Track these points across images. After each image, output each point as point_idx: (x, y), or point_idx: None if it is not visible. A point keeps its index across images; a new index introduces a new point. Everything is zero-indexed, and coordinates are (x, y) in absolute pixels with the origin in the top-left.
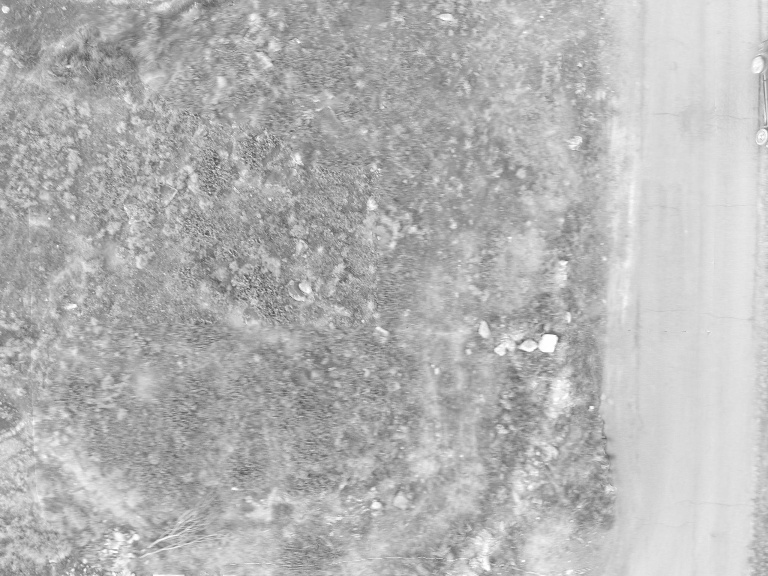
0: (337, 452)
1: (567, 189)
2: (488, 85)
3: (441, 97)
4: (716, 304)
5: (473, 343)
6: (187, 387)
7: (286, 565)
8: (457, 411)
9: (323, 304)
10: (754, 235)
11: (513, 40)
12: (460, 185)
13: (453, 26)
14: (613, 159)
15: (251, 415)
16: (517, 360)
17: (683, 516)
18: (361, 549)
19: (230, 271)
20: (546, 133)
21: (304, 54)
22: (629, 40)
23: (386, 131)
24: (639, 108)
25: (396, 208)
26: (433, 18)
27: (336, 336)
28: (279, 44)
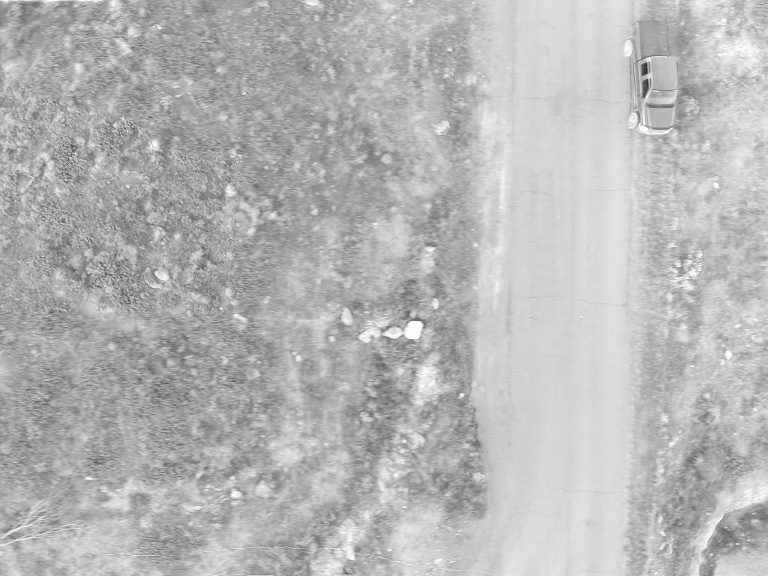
0: (194, 441)
1: (435, 174)
2: (354, 70)
3: (305, 82)
4: (589, 290)
5: (336, 330)
6: (40, 376)
7: (144, 555)
8: (321, 399)
9: (180, 291)
10: (627, 220)
11: (381, 25)
12: (322, 171)
13: (319, 11)
14: (484, 144)
15: (106, 404)
16: (382, 347)
17: (556, 504)
18: (222, 539)
19: (85, 259)
20: (414, 118)
21: (165, 40)
22: (500, 24)
23: (247, 117)
24: (510, 93)
25: (255, 194)
26: (299, 3)
27: (193, 324)
28: (139, 30)
